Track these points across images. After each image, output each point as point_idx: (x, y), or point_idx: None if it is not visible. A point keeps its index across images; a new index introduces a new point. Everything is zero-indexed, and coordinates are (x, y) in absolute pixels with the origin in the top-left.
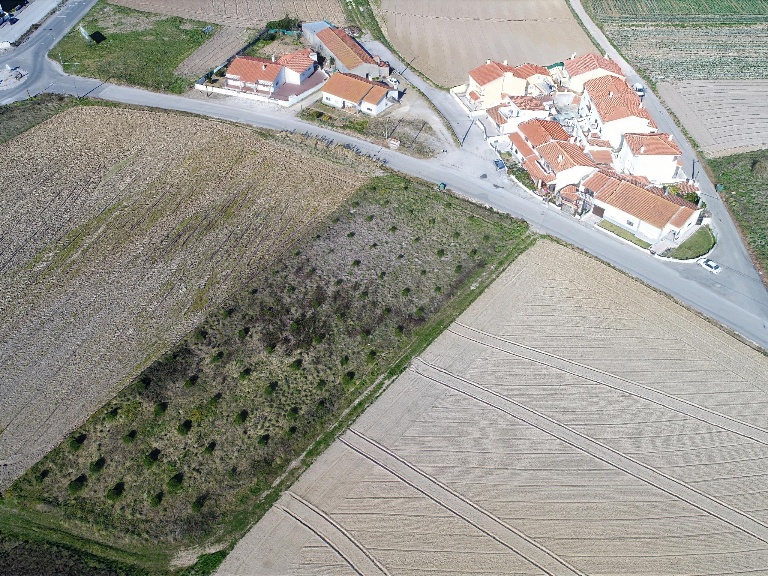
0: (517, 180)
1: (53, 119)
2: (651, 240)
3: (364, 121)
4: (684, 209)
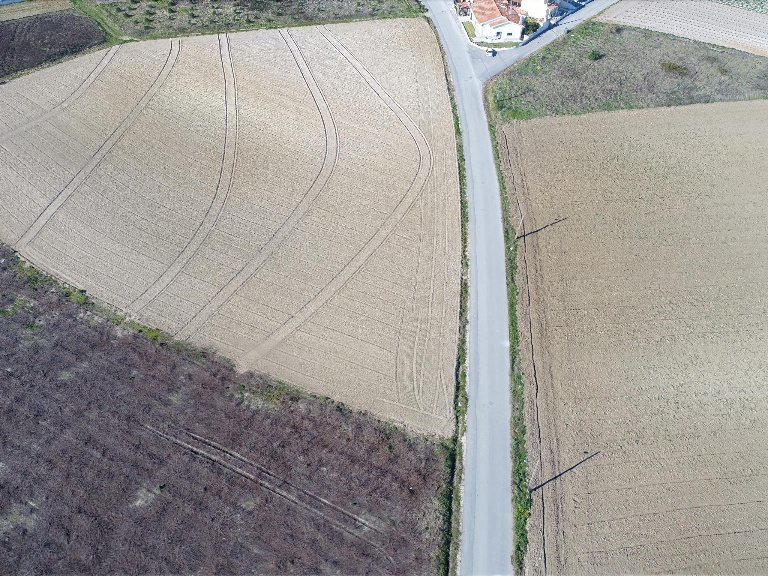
0: None
1: None
2: (479, 35)
3: None
4: (505, 19)
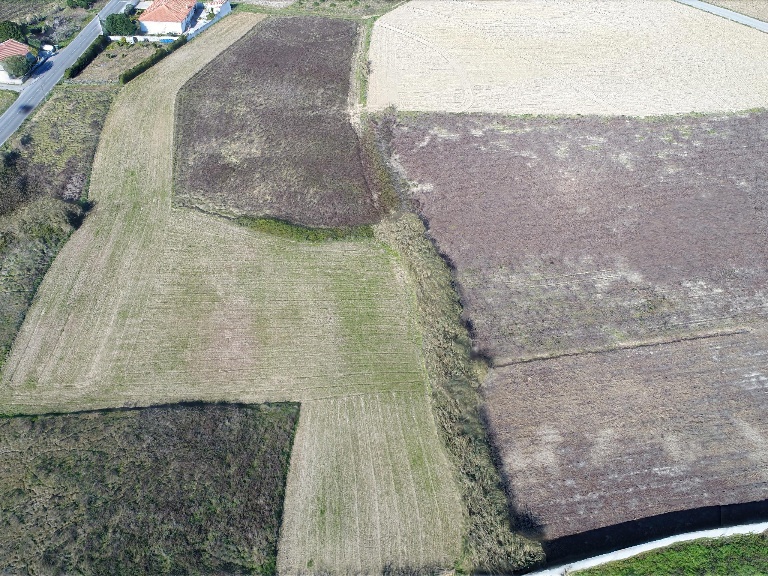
0: None
1: None
2: None
3: None
4: None
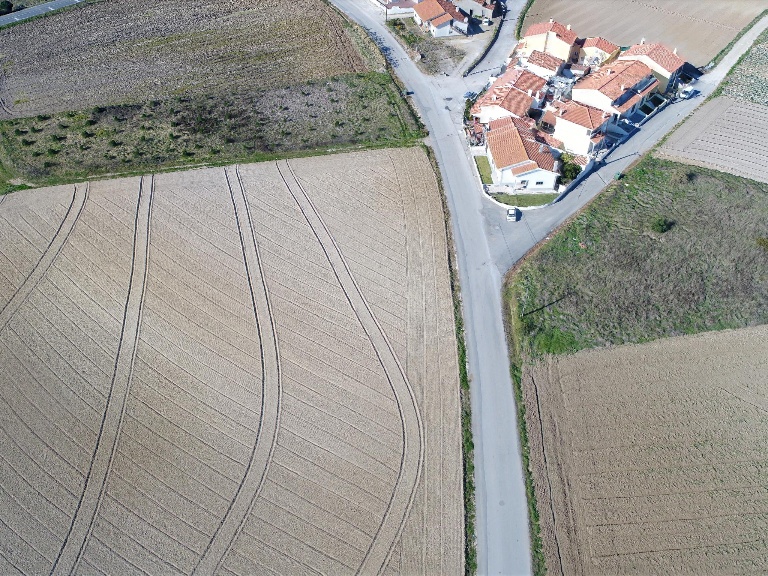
0: None
1: None
2: (497, 181)
3: (421, 37)
4: (533, 164)
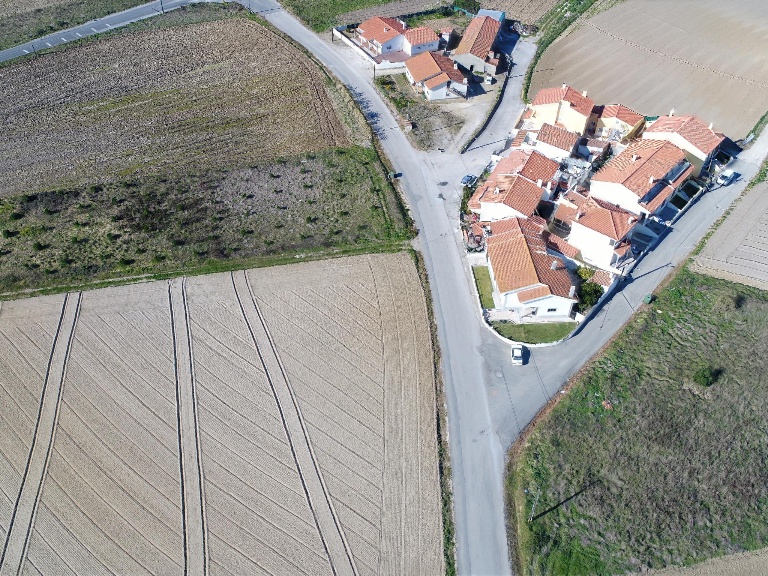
0: (462, 198)
1: (220, 21)
2: (500, 304)
3: (413, 101)
4: (544, 287)
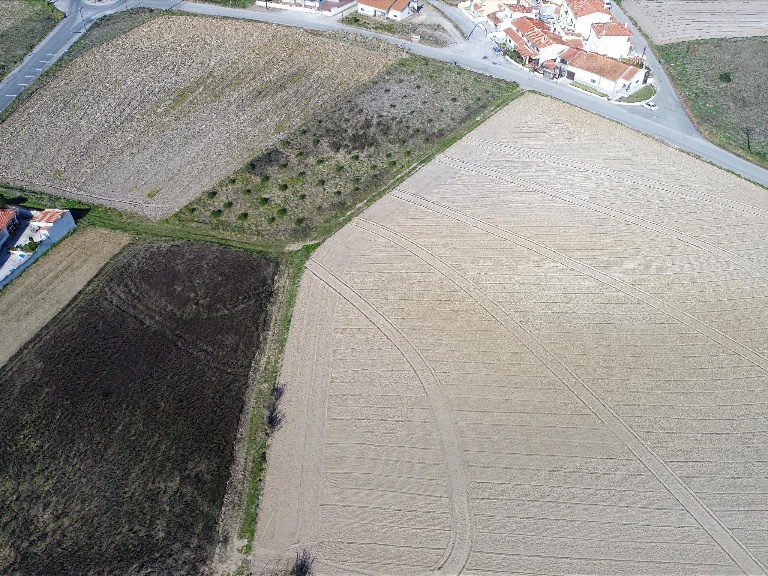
0: (510, 59)
1: (148, 24)
2: (609, 92)
3: (392, 24)
4: (632, 68)
